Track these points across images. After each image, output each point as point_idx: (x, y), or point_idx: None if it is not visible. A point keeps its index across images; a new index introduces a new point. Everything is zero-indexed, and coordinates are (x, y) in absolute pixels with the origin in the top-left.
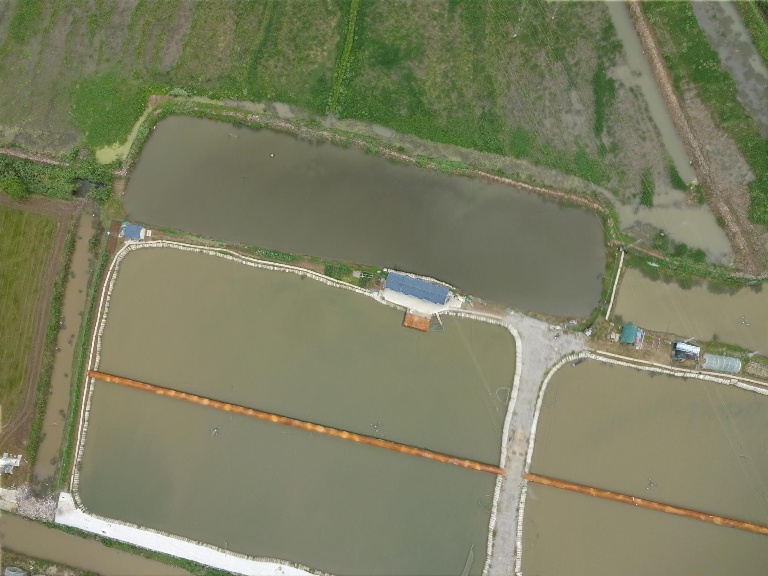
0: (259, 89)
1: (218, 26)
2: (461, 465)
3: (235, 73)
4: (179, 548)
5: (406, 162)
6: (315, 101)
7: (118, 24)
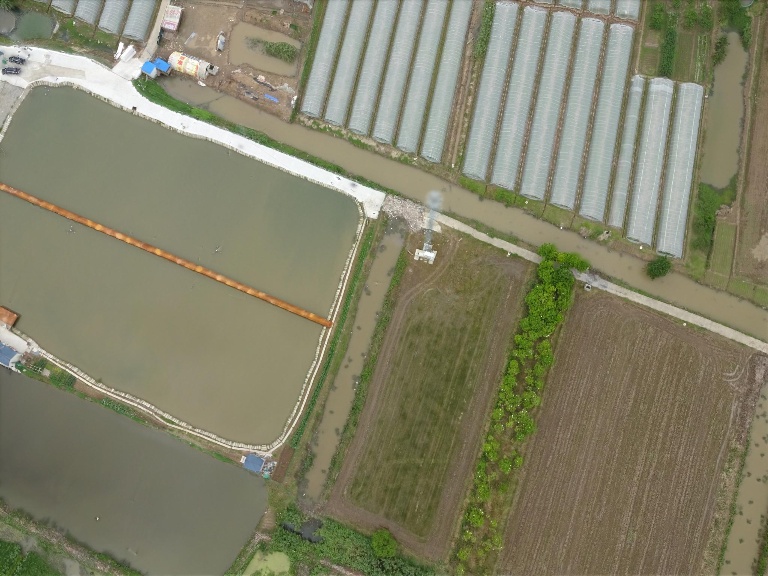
0: None
1: None
2: (8, 187)
3: None
4: (270, 156)
5: None
6: (35, 571)
7: None
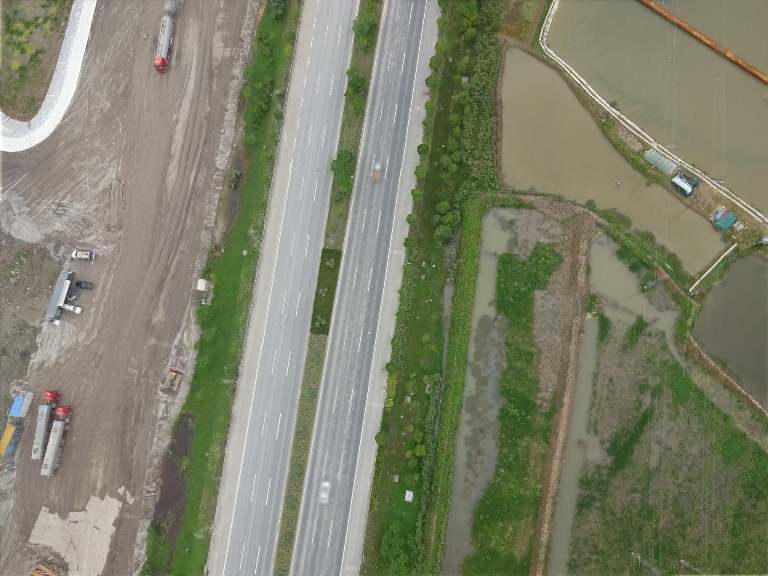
0: None
1: None
2: None
3: None
4: None
5: None
6: None
7: None
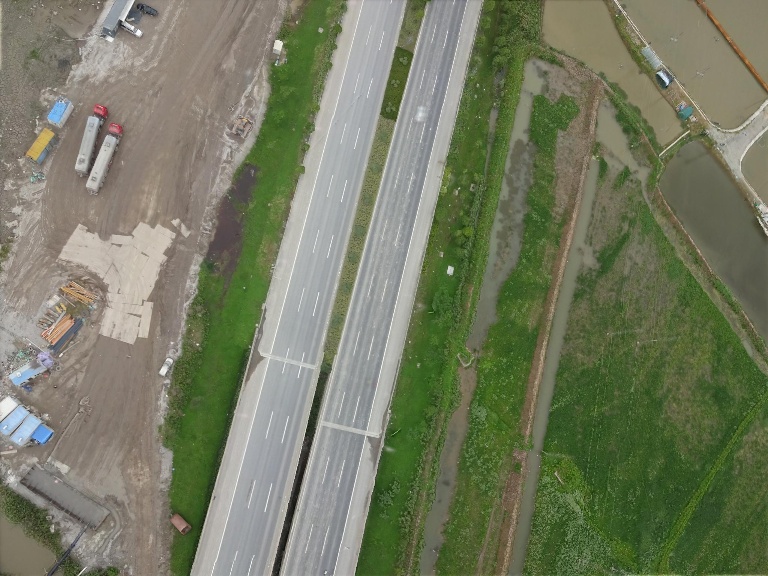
0: None
1: None
2: None
3: None
4: None
5: None
6: None
7: None
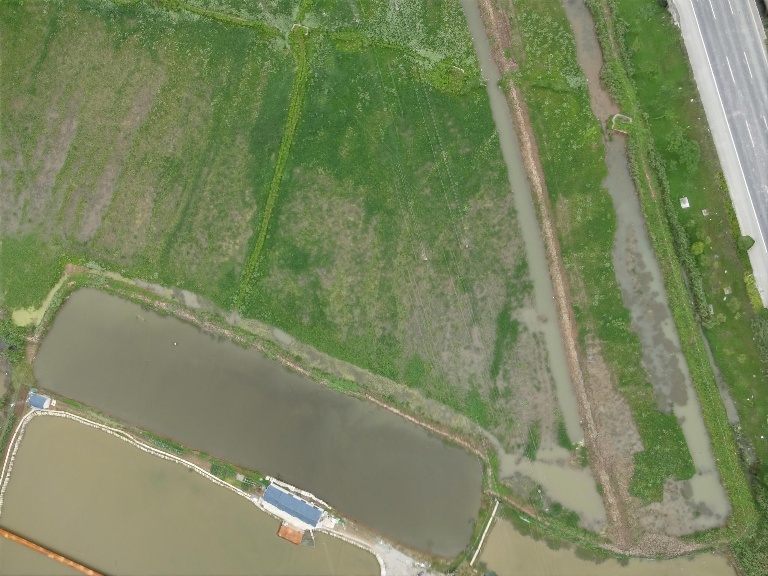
0: (169, 275)
1: (137, 202)
2: None
3: (148, 254)
4: None
5: (301, 374)
6: (221, 296)
7: (43, 184)
